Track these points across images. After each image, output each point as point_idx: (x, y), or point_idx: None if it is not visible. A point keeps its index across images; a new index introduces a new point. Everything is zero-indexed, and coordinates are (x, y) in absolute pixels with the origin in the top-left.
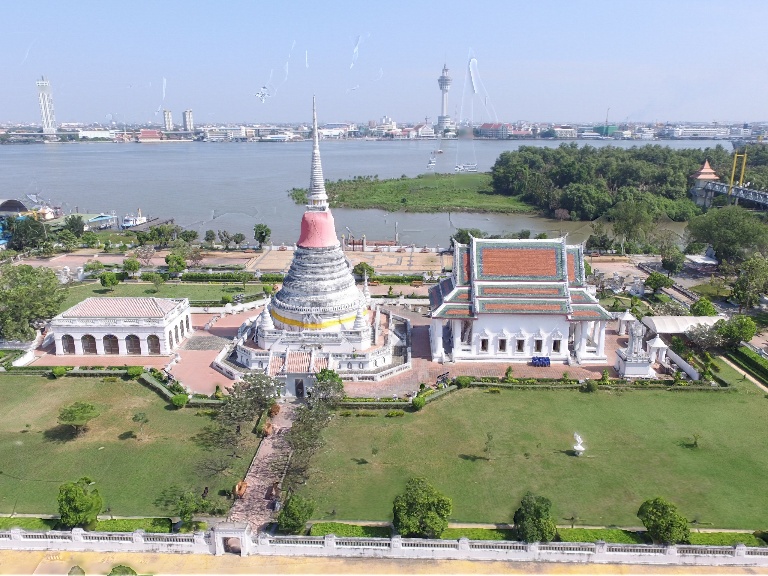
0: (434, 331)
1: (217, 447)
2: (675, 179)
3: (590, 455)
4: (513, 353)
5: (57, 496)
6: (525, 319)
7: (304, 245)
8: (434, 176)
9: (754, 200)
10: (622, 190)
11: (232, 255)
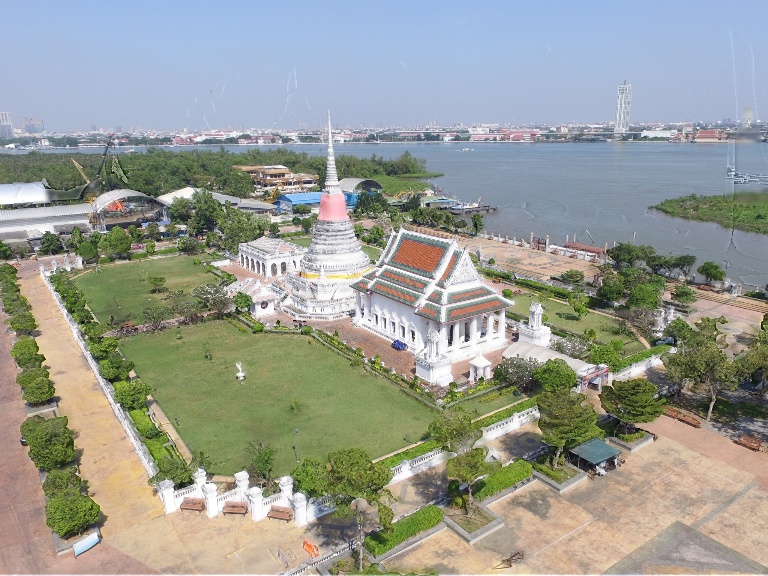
0: None
1: (169, 313)
2: None
3: (244, 382)
4: None
5: (105, 306)
6: (396, 304)
7: None
8: None
9: None
10: None
11: (450, 236)
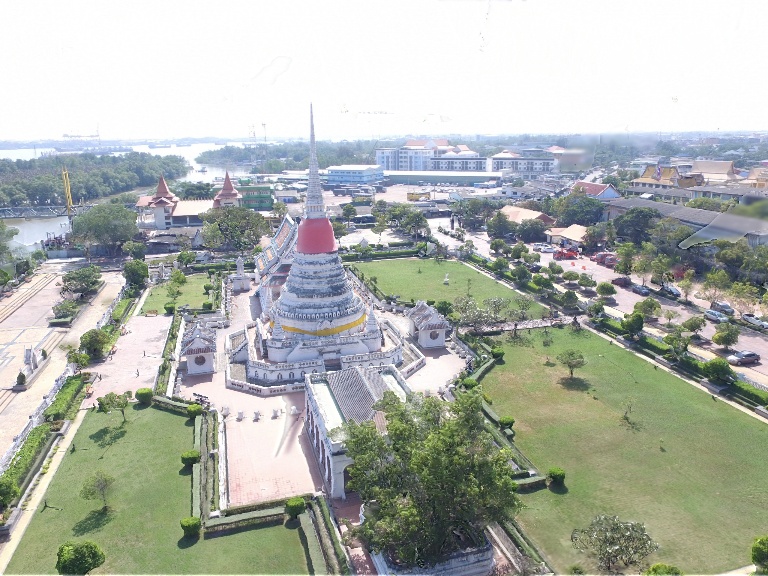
0: None
1: None
2: None
3: None
4: None
5: (623, 359)
6: None
7: None
8: None
9: None
10: None
11: None
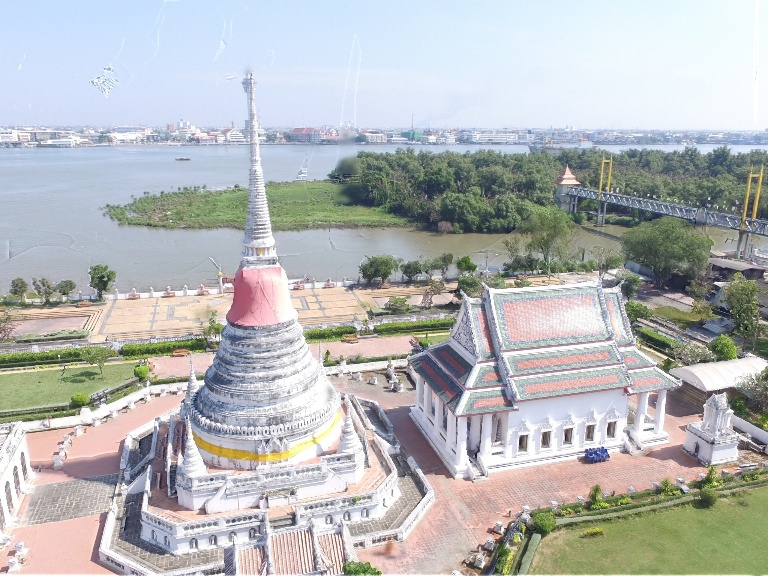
0: (435, 425)
1: None
2: (543, 185)
3: None
4: (559, 448)
5: None
6: (574, 399)
7: (245, 323)
8: (304, 189)
9: (628, 206)
10: (503, 199)
11: (58, 313)
